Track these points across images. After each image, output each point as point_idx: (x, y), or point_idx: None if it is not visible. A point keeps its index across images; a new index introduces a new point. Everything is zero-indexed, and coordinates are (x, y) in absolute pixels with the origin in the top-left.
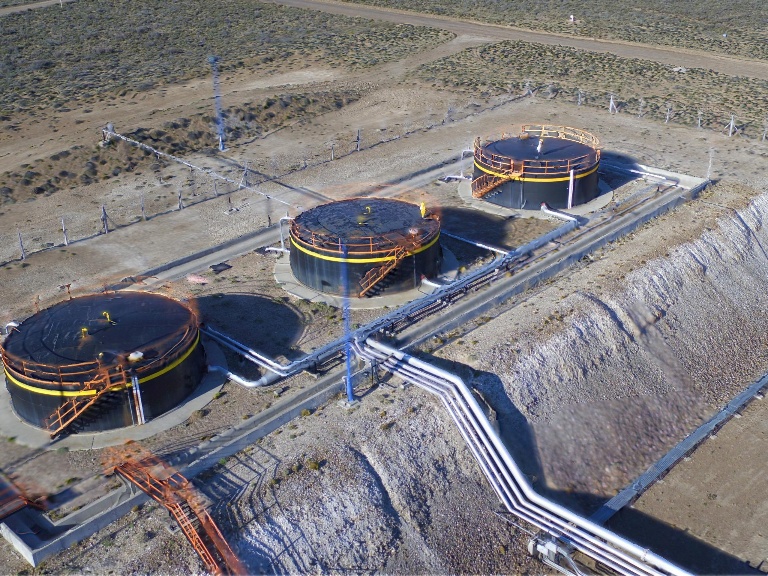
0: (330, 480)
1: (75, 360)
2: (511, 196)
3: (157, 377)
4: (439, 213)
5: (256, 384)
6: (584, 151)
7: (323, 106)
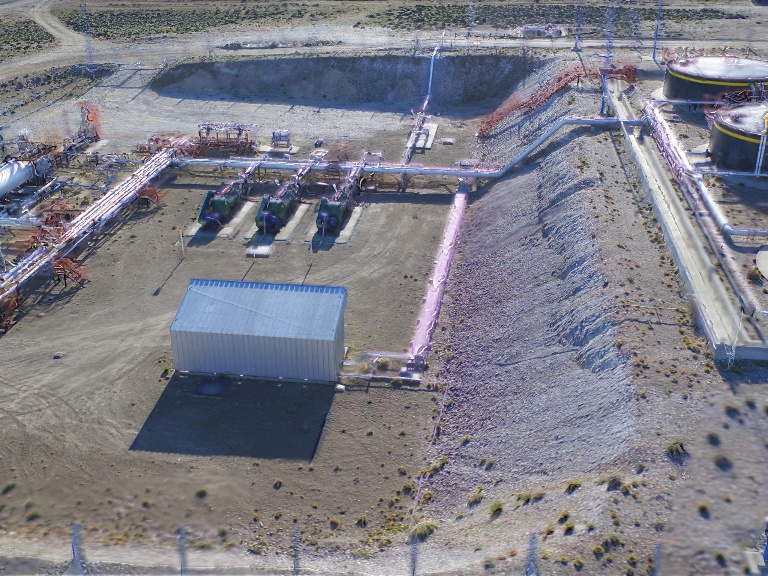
0: None
1: (703, 59)
2: None
3: None
4: None
5: None
6: None
7: None
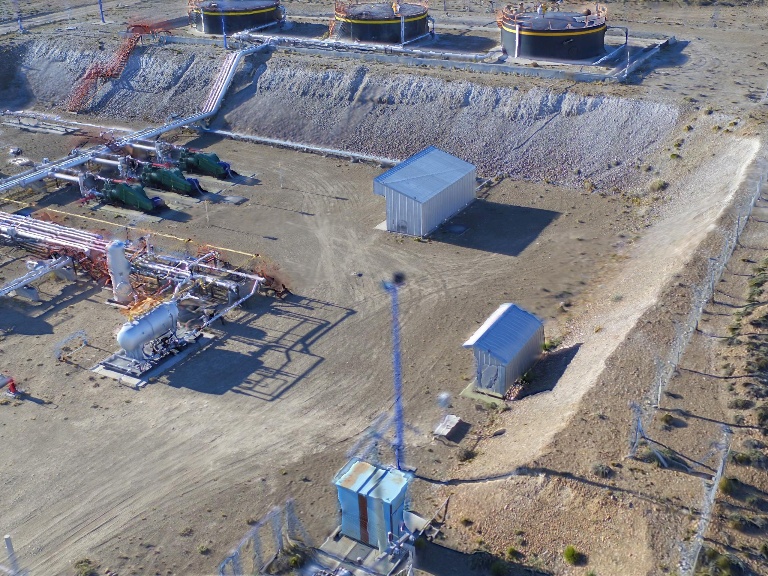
0: (175, 58)
1: None
2: None
3: (211, 15)
4: (481, 41)
5: None
6: (573, 25)
7: (687, 0)
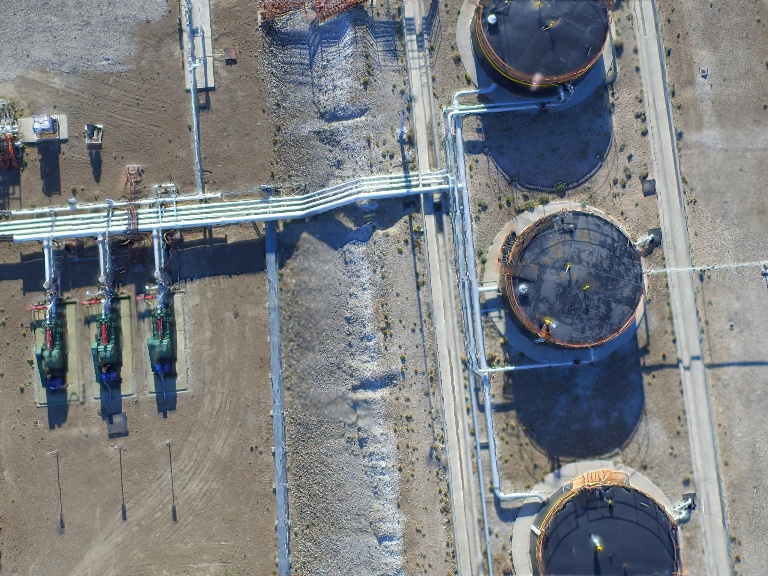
0: None
1: None
2: None
3: None
4: (618, 420)
5: (455, 96)
6: None
7: None
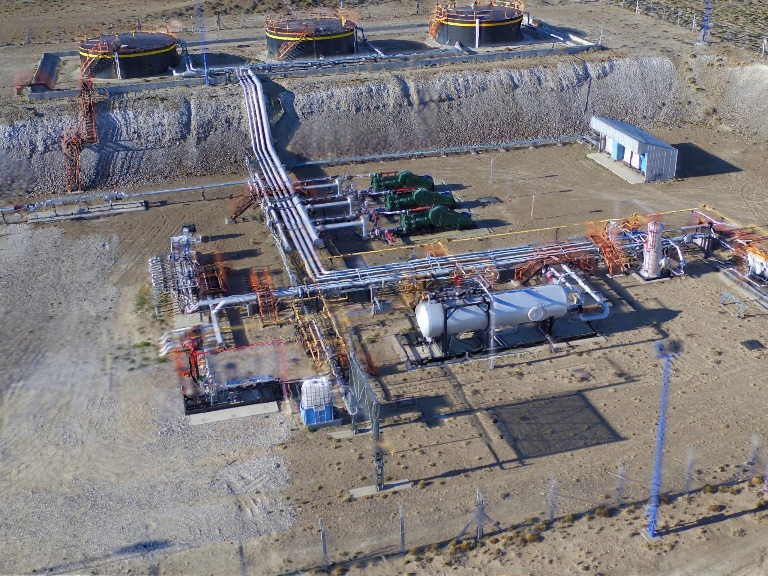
0: (164, 106)
1: None
2: (443, 35)
3: (130, 57)
4: (399, 42)
5: (178, 74)
6: (511, 14)
7: None
